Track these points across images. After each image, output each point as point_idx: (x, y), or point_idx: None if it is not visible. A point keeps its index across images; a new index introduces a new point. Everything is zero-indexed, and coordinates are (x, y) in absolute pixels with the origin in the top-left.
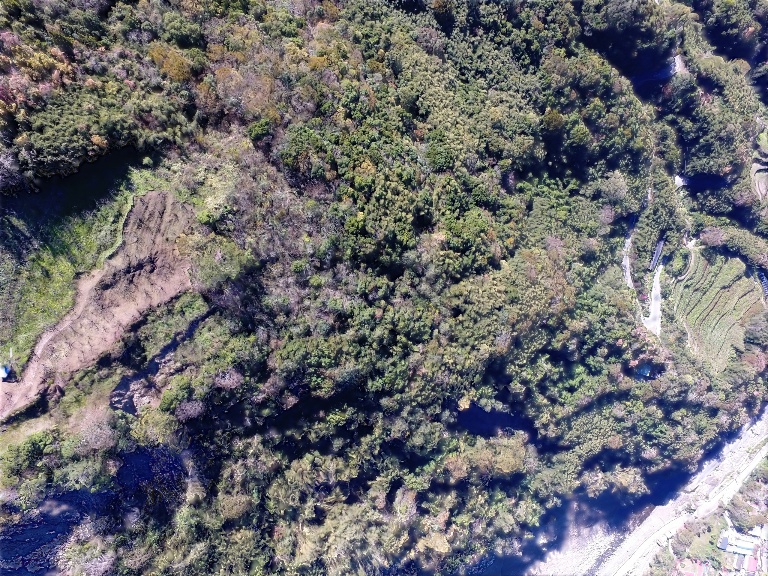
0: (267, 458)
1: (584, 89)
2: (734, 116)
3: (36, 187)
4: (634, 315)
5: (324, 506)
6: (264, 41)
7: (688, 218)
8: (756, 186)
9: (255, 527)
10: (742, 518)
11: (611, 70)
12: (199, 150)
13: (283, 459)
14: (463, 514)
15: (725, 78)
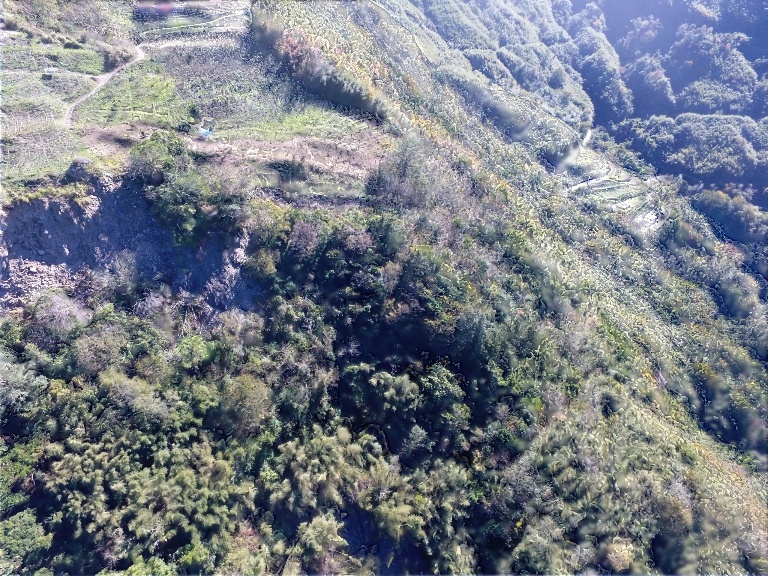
0: None
1: (744, 368)
2: None
3: (327, 81)
4: None
5: None
6: None
7: None
8: None
9: (235, 467)
10: None
11: None
12: None
13: None
14: None
15: None
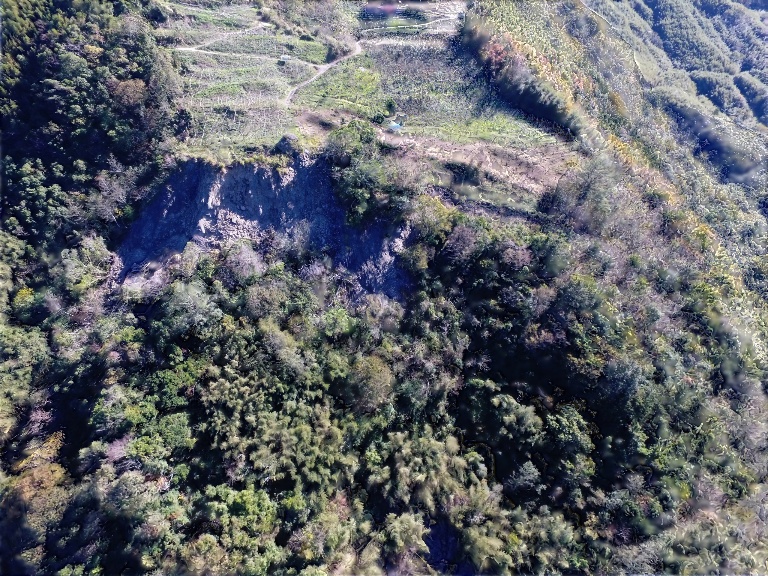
0: None
1: None
2: None
3: (524, 90)
4: None
5: None
6: None
7: None
8: None
9: (346, 438)
10: None
11: None
12: None
13: None
14: None
15: None
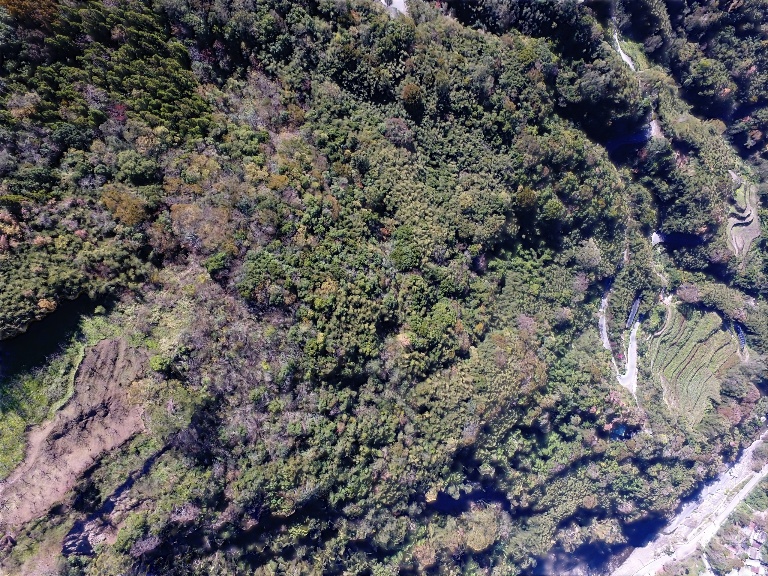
0: (228, 574)
1: (557, 164)
2: (709, 178)
3: None
4: (609, 378)
5: None
6: (224, 164)
7: (665, 275)
8: (733, 240)
9: None
10: (719, 562)
11: (585, 142)
12: (154, 288)
13: (246, 570)
14: None
15: (700, 141)
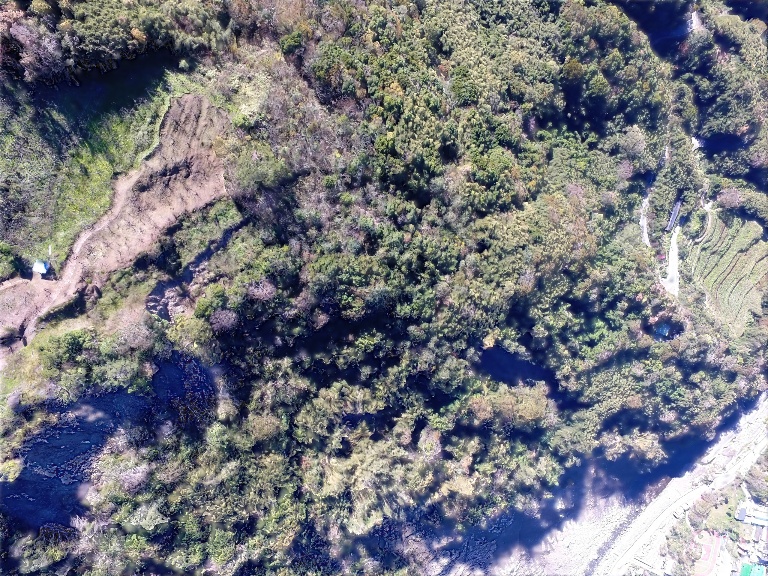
0: (297, 381)
1: (603, 39)
2: (751, 74)
3: (77, 80)
4: None
5: (350, 442)
6: None
7: (705, 180)
8: None
9: (284, 453)
10: (760, 488)
11: (629, 22)
12: (232, 60)
13: (311, 385)
14: (485, 463)
15: (742, 36)
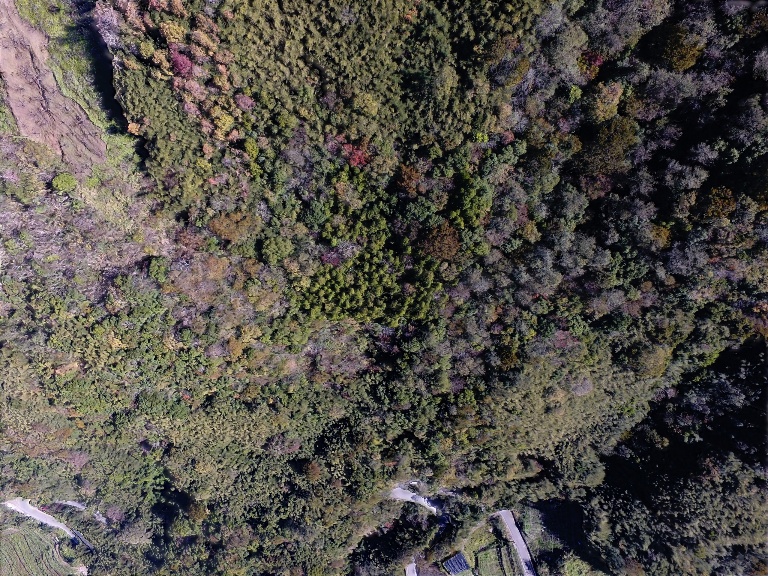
0: None
1: None
2: None
3: None
4: None
5: None
6: None
7: None
8: None
9: None
10: None
11: None
12: None
13: None
14: None
15: None
